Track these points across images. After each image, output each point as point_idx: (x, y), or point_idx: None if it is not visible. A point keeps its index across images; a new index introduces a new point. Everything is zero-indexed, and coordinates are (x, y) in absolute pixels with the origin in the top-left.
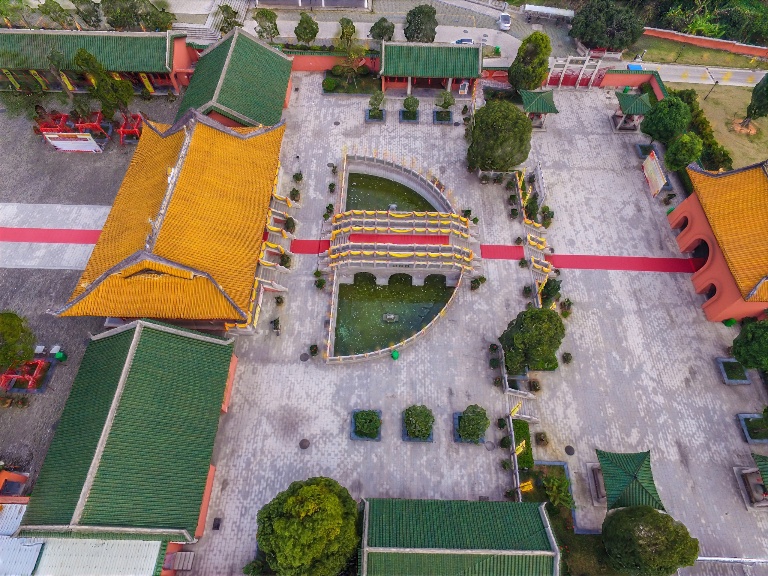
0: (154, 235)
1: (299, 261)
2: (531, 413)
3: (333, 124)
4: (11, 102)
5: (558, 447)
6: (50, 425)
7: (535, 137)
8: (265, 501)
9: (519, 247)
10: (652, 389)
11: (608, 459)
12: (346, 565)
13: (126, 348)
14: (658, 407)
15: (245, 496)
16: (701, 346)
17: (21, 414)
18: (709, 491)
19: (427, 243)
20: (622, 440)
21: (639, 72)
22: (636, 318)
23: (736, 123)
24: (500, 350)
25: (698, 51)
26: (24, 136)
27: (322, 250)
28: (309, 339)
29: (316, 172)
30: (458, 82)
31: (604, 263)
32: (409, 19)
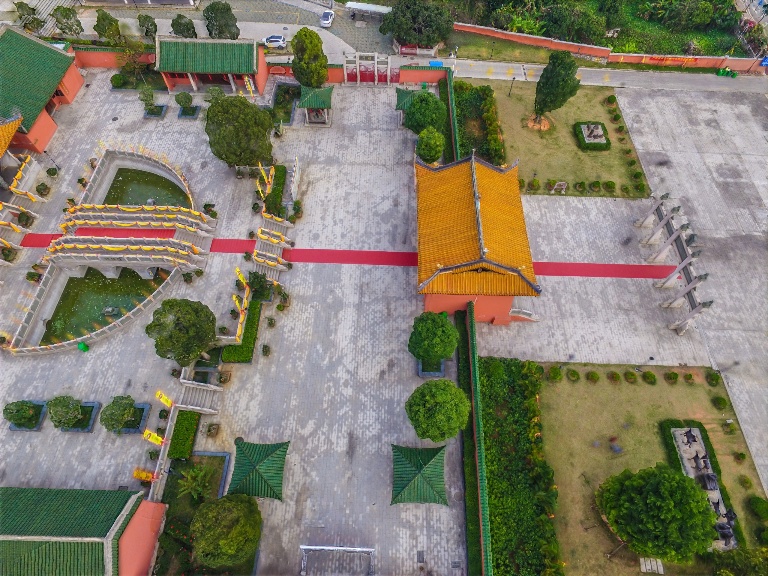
0: None
1: (26, 254)
2: (213, 405)
3: (111, 120)
4: None
5: (228, 438)
6: None
7: (317, 133)
8: None
9: (252, 241)
10: (344, 381)
11: (242, 449)
12: None
13: None
14: (343, 399)
15: None
16: None
17: None
18: (364, 482)
19: (151, 237)
20: (295, 431)
21: (432, 68)
22: (353, 311)
23: (531, 119)
24: None
25: (518, 48)
26: None
27: None
28: (7, 331)
29: (76, 167)
30: (240, 78)
31: (341, 257)
32: (205, 16)
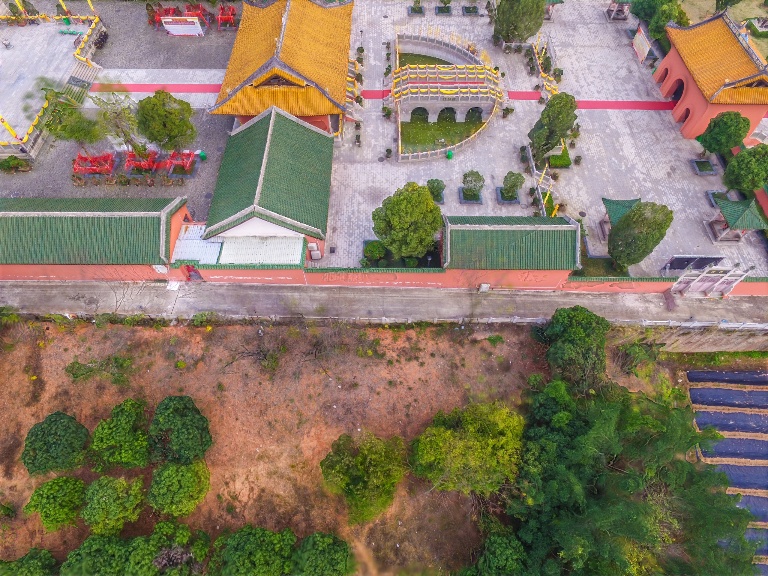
0: (278, 53)
1: (369, 103)
2: None
3: (383, 17)
4: (123, 5)
5: (574, 212)
6: (203, 195)
7: (545, 26)
8: (365, 238)
9: (537, 92)
10: (643, 179)
11: (611, 201)
12: (435, 240)
13: (265, 126)
14: (647, 189)
15: (350, 235)
16: (679, 153)
17: (181, 190)
18: (685, 234)
19: None
20: None
21: None
22: (629, 138)
23: (708, 17)
24: (528, 151)
25: None
26: (139, 27)
27: (385, 96)
28: (383, 149)
29: (373, 48)
30: None
31: (604, 105)
32: None
